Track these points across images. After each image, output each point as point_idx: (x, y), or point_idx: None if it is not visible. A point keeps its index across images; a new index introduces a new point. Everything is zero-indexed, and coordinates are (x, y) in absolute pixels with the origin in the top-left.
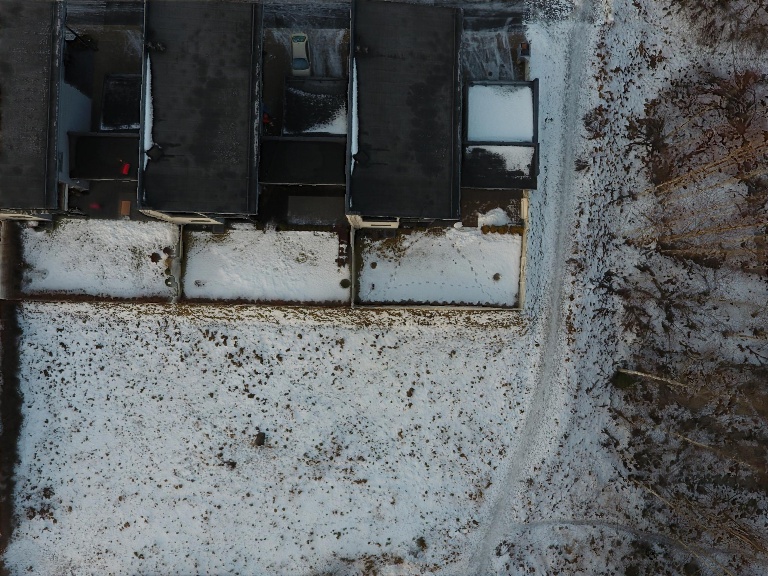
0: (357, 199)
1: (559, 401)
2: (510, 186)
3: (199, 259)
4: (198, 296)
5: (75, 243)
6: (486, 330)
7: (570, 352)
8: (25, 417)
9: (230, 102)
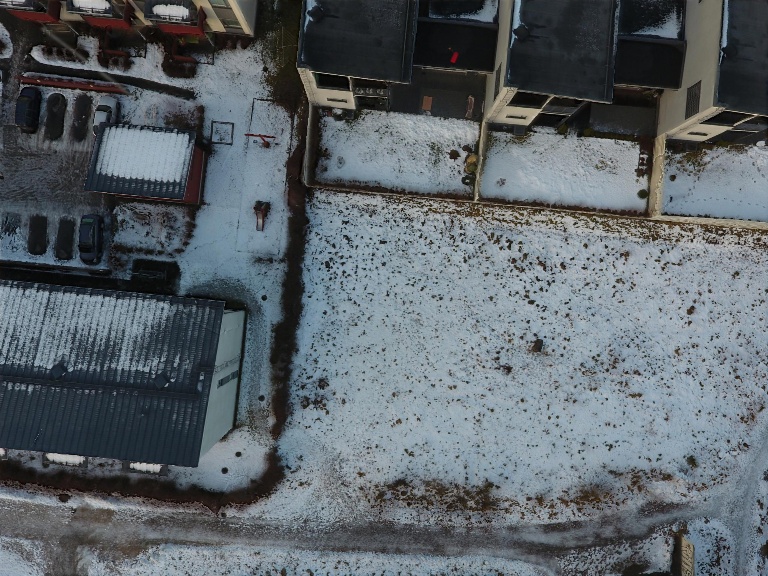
0: (723, 92)
1: None
2: None
3: (498, 159)
4: (494, 196)
5: (374, 135)
6: None
7: None
8: (304, 307)
9: None
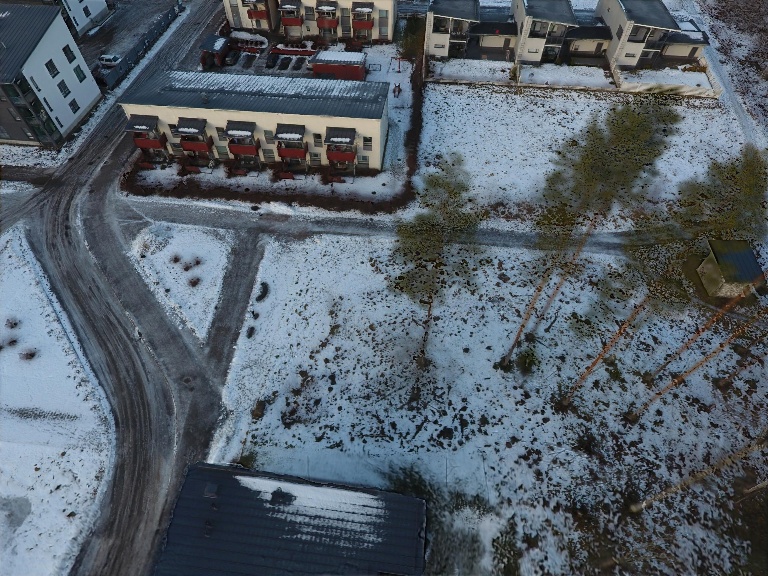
0: None
1: (763, 141)
2: (695, 43)
3: (527, 72)
4: None
5: None
6: (700, 110)
7: (757, 123)
8: (424, 127)
9: (558, 1)
